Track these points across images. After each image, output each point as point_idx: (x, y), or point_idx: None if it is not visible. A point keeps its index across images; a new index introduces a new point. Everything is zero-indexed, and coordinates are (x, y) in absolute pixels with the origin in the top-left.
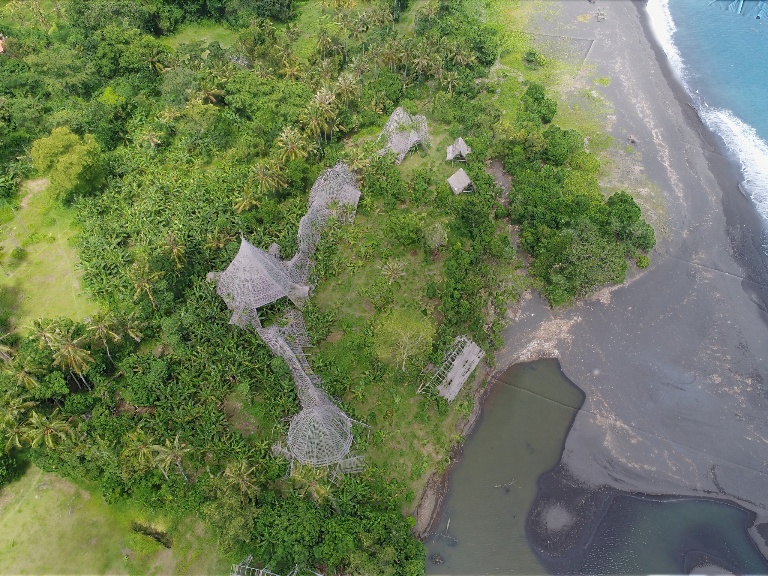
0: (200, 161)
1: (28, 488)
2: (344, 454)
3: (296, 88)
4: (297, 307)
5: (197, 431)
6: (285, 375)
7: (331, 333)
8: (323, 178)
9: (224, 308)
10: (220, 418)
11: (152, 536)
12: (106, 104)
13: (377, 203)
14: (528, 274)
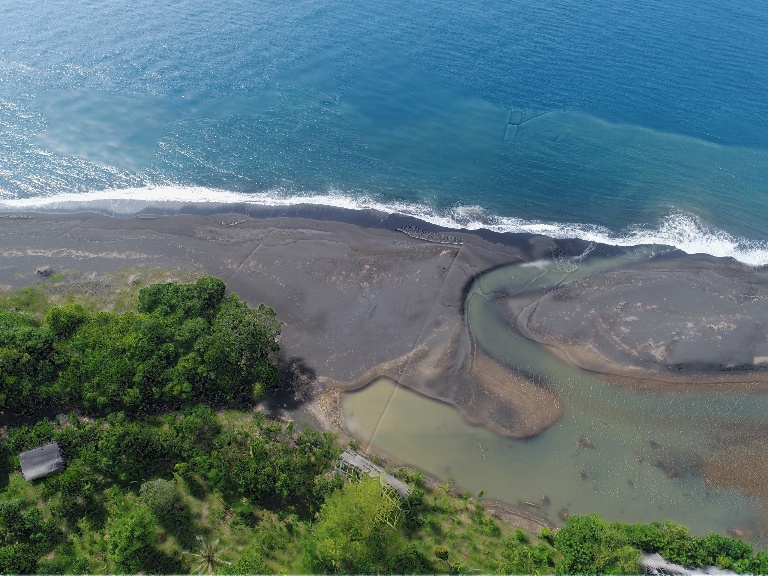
0: None
1: None
2: None
3: None
4: None
5: None
6: None
7: None
8: None
9: None
10: None
11: None
12: None
13: None
14: (225, 403)
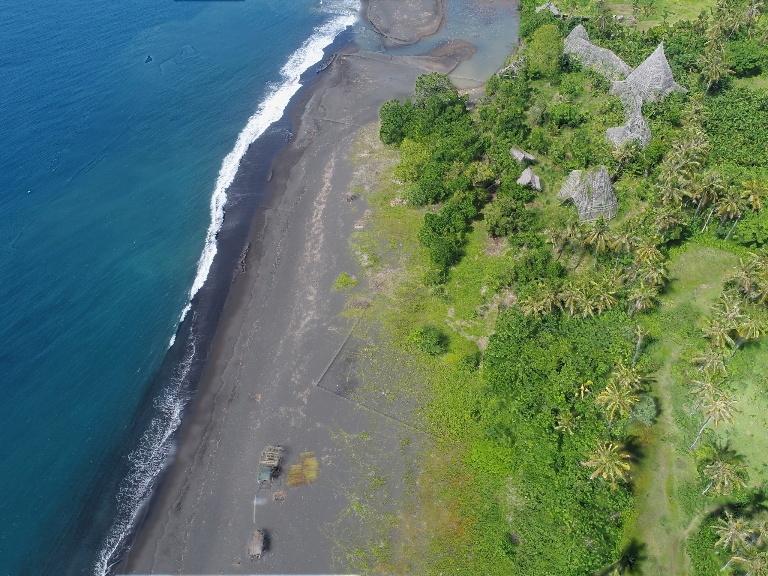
0: None
1: None
2: None
3: None
4: None
5: None
6: None
7: None
8: None
9: None
10: None
11: None
12: None
13: None
14: None
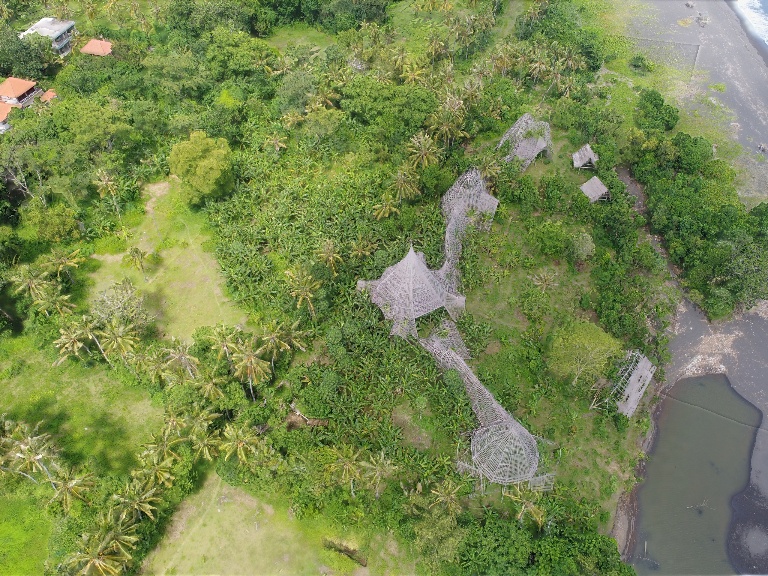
0: (322, 166)
1: (209, 501)
2: (533, 472)
3: (421, 93)
4: (451, 317)
5: (374, 445)
6: (460, 388)
7: (488, 345)
8: (462, 185)
9: (381, 318)
10: (397, 432)
11: (345, 554)
12: (224, 107)
13: (509, 211)
14: (678, 286)
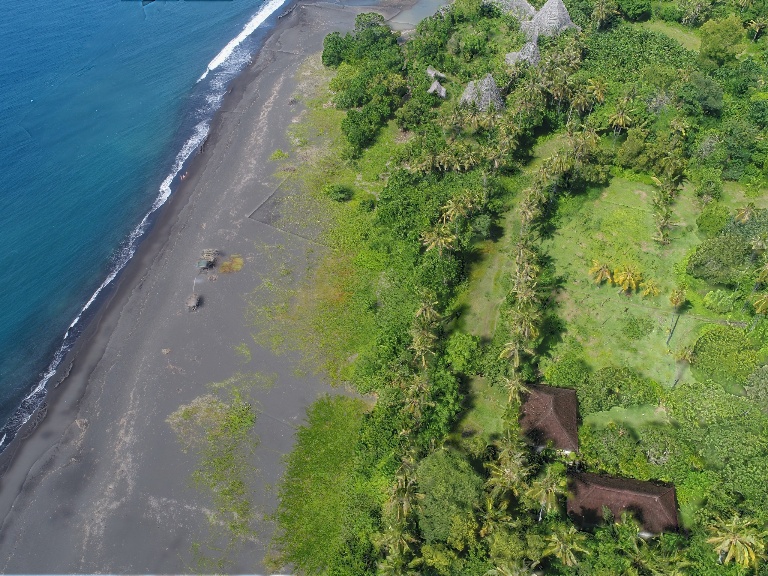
0: None
1: None
2: None
3: None
4: None
5: None
6: None
7: None
8: None
9: None
10: None
11: None
12: None
13: None
14: None
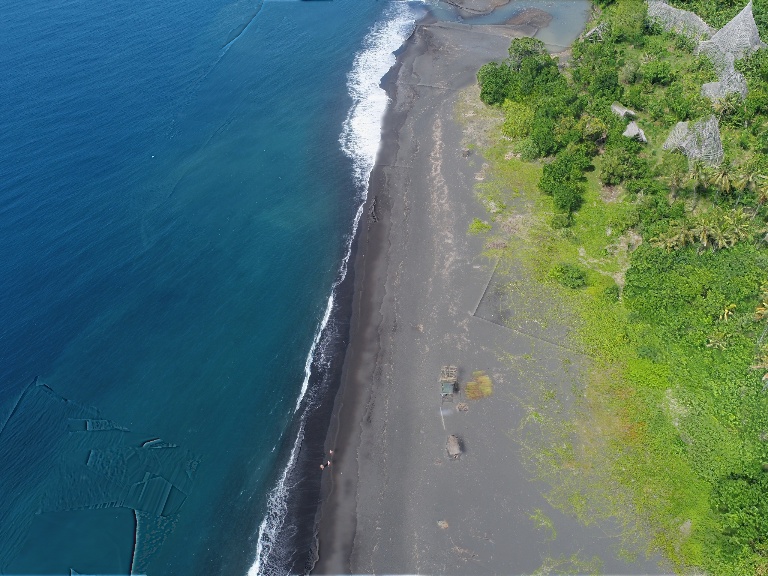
0: None
1: None
2: None
3: None
4: None
5: None
6: None
7: None
8: None
9: None
10: None
11: None
12: None
13: None
14: None
